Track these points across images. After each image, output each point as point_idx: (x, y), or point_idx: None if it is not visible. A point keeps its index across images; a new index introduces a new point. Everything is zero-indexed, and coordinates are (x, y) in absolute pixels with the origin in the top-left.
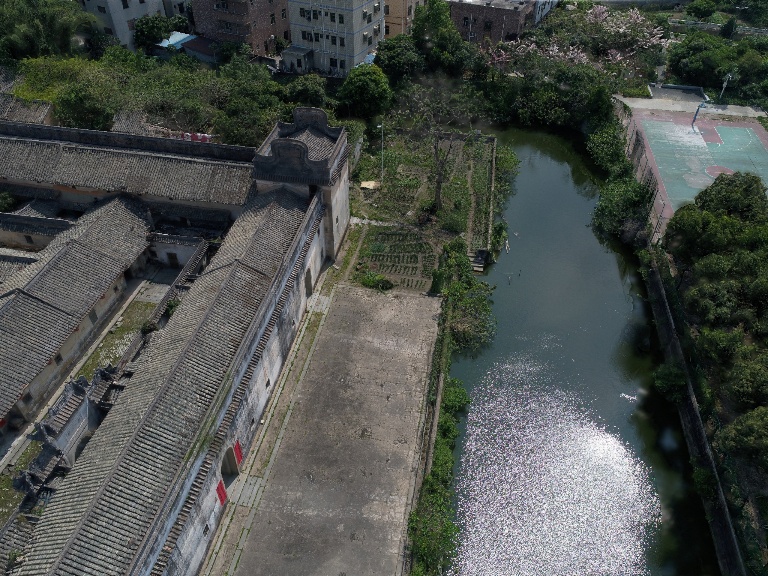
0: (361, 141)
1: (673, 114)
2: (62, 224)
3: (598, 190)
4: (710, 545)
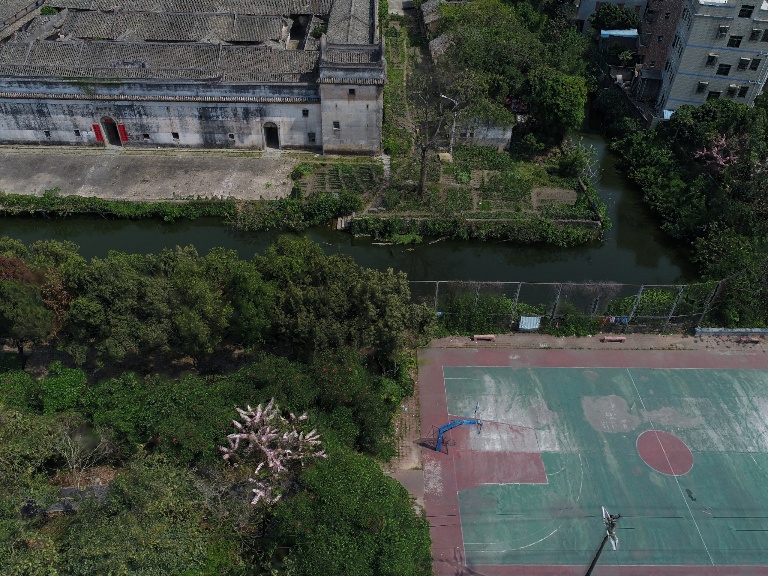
0: (503, 134)
1: None
2: None
3: None
4: None
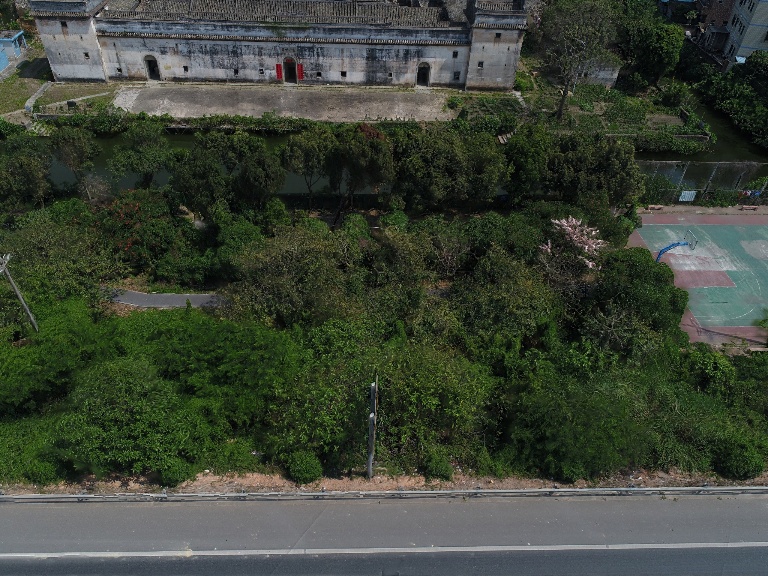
0: (611, 74)
1: None
2: None
3: None
4: None
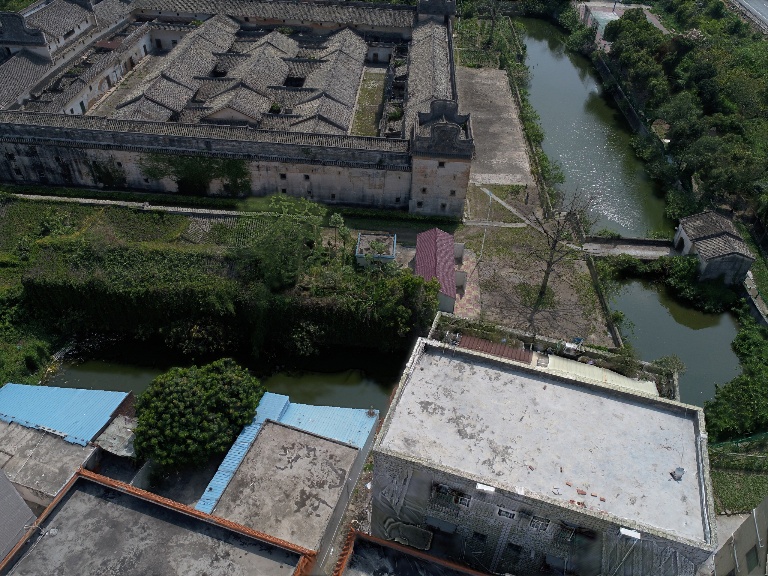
0: None
1: (602, 8)
2: (324, 39)
3: (563, 53)
4: (627, 123)
